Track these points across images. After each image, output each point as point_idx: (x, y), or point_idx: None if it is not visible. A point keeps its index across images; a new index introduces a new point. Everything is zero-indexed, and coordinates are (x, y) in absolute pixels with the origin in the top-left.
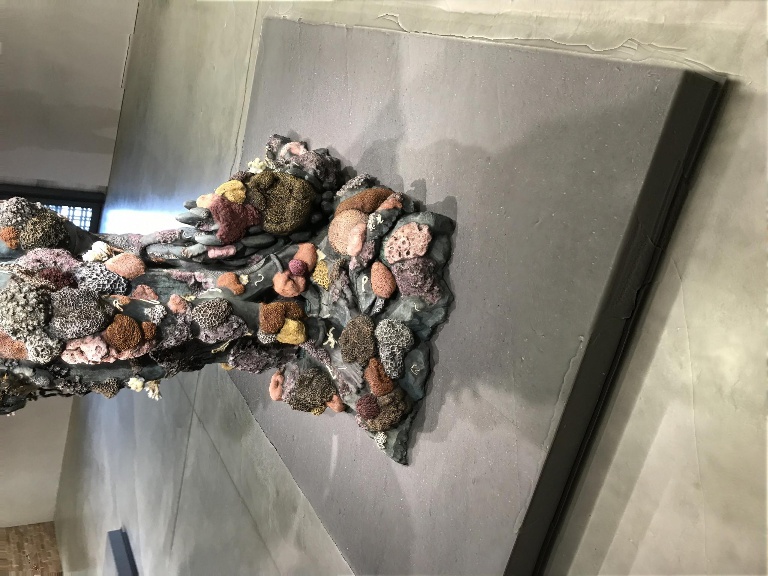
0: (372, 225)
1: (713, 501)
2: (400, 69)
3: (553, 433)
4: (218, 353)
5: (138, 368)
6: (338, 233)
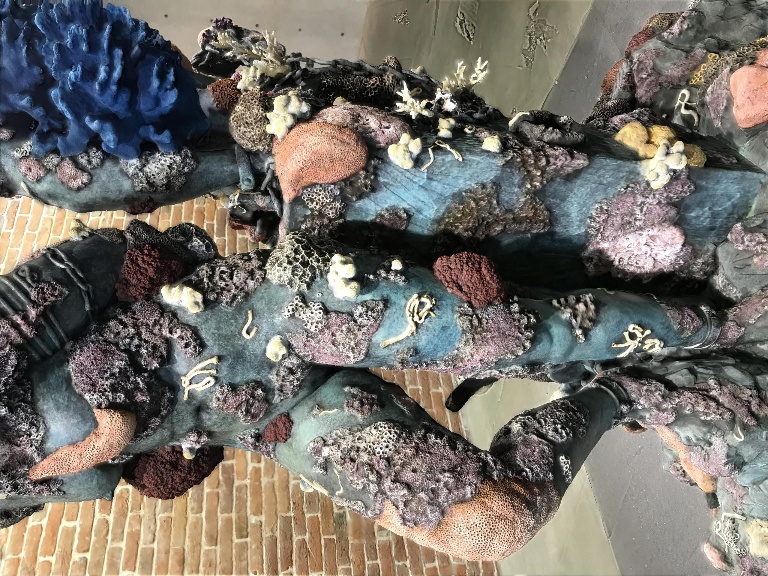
0: None
1: None
2: None
3: (583, 19)
4: None
5: None
6: None
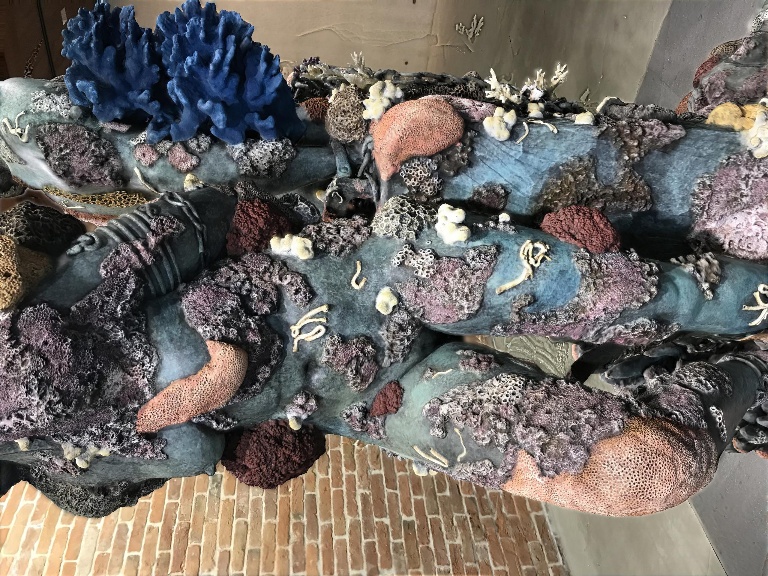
0: None
1: (646, 56)
2: None
3: (639, 82)
4: None
5: None
6: None
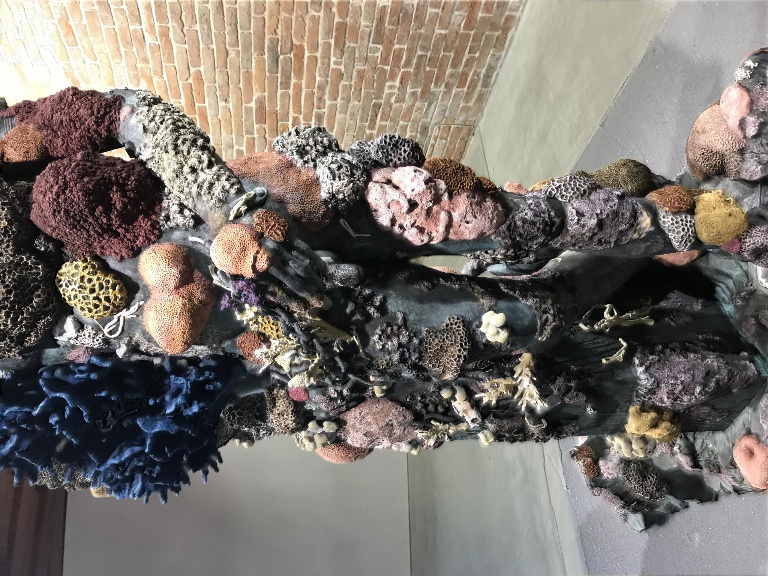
0: (745, 73)
1: None
2: (675, 49)
3: None
4: (614, 364)
5: (490, 300)
6: (704, 138)
